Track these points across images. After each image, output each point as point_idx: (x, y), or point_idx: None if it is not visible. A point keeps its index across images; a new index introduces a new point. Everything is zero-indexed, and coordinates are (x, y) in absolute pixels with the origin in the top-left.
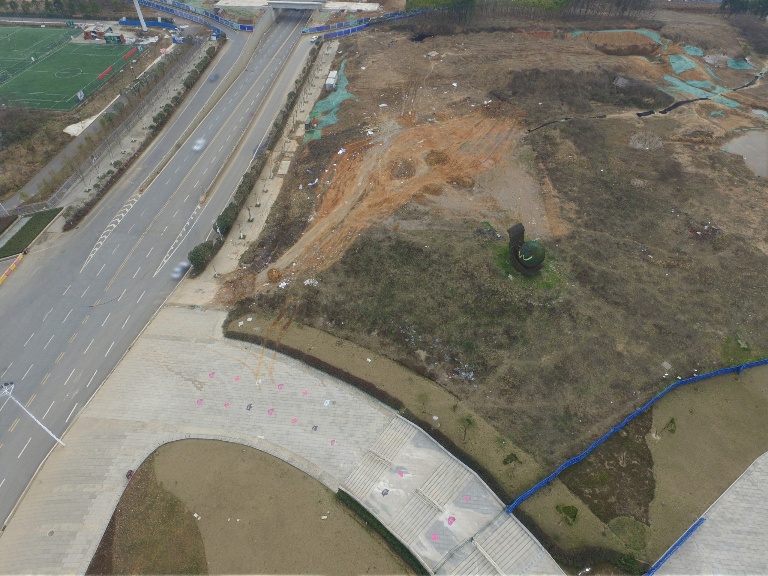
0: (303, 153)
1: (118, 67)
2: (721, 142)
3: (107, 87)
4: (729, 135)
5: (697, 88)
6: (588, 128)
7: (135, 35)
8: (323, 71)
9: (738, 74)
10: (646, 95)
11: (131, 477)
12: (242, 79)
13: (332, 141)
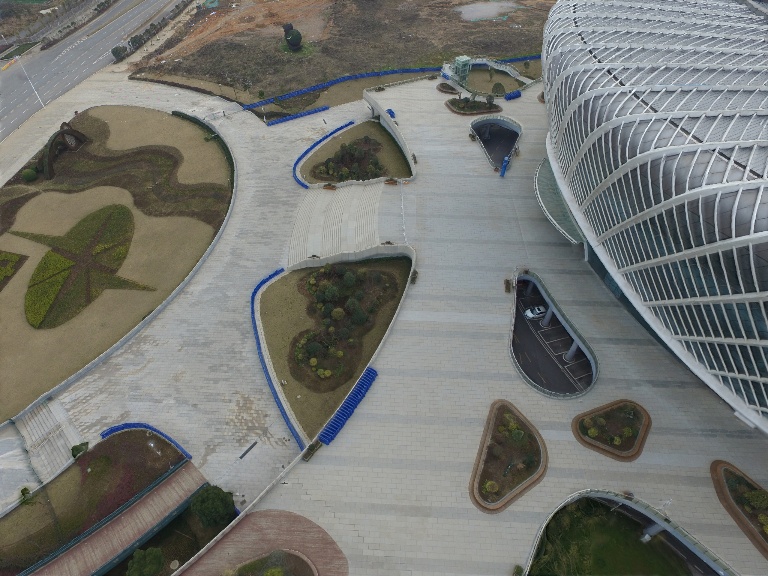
0: (191, 18)
1: None
2: (454, 7)
3: None
4: (462, 4)
5: None
6: (372, 0)
7: None
8: None
9: None
10: None
11: (77, 114)
12: None
13: (208, 9)
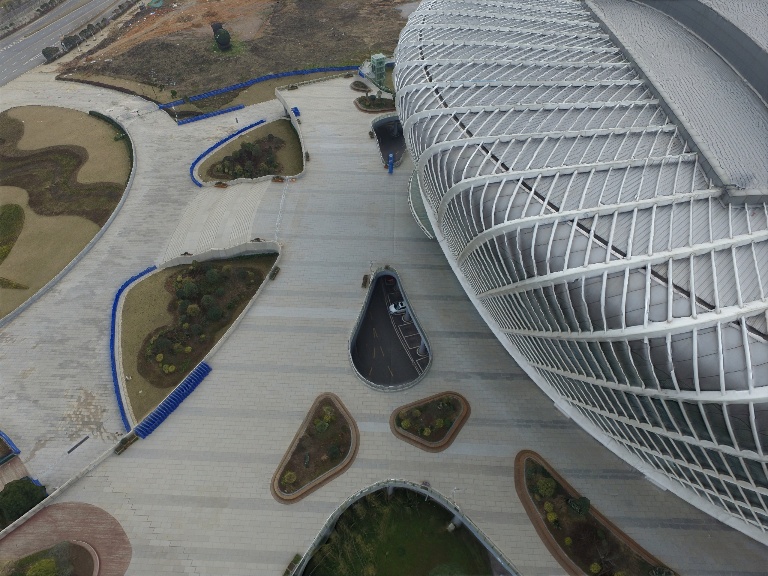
0: None
1: None
2: (396, 5)
3: None
4: (404, 2)
5: None
6: None
7: None
8: None
9: None
10: None
11: None
12: None
13: (148, 9)
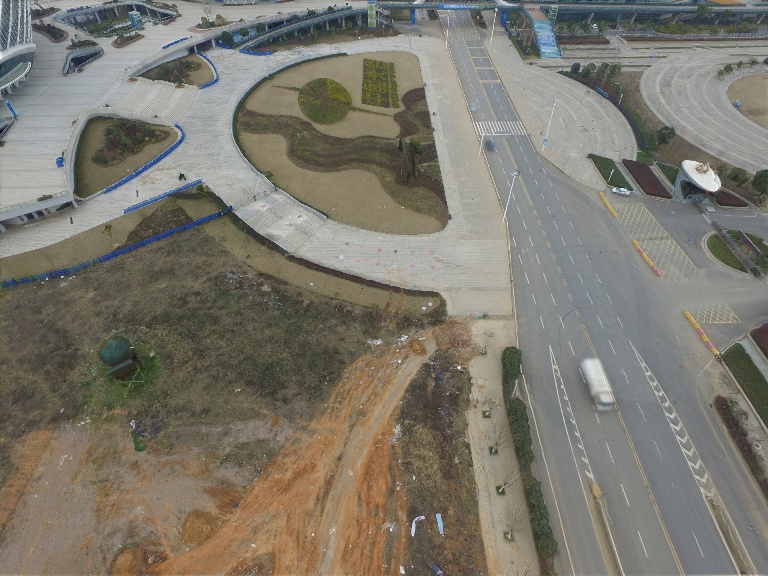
0: None
1: None
2: None
3: None
4: None
5: None
6: None
7: None
8: None
9: None
10: None
11: None
12: None
13: None
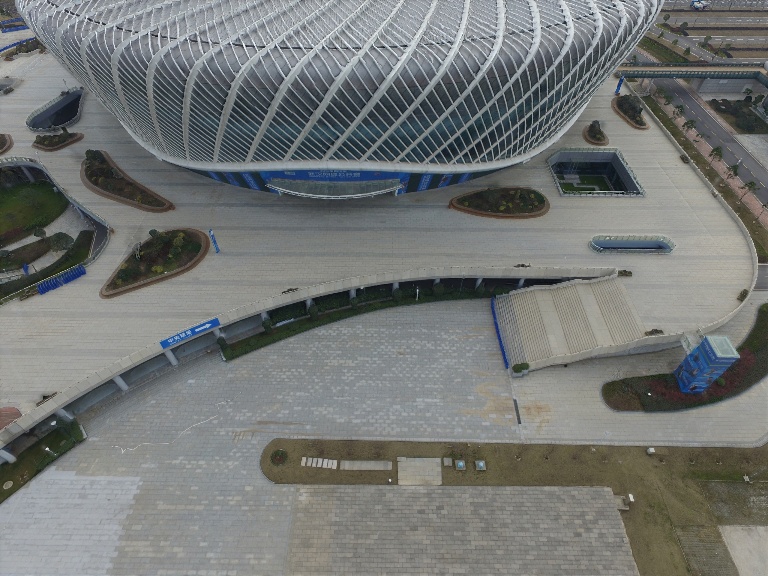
0: None
1: None
2: None
3: None
4: None
5: None
6: None
7: None
8: None
9: None
10: None
11: None
12: None
13: None
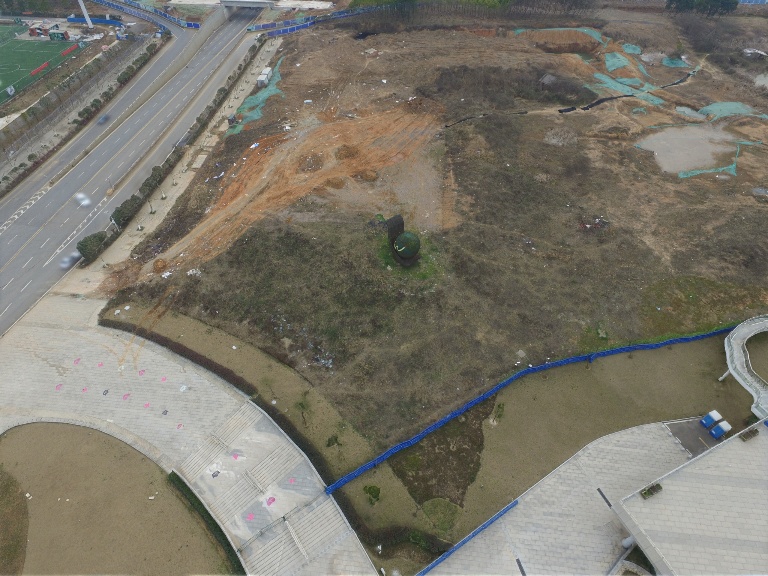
0: (219, 147)
1: (56, 63)
2: (636, 138)
3: (41, 83)
4: (646, 131)
5: (625, 85)
6: (504, 124)
7: (81, 32)
8: (260, 68)
9: (671, 72)
10: (569, 92)
11: None
12: (180, 75)
13: (247, 136)
